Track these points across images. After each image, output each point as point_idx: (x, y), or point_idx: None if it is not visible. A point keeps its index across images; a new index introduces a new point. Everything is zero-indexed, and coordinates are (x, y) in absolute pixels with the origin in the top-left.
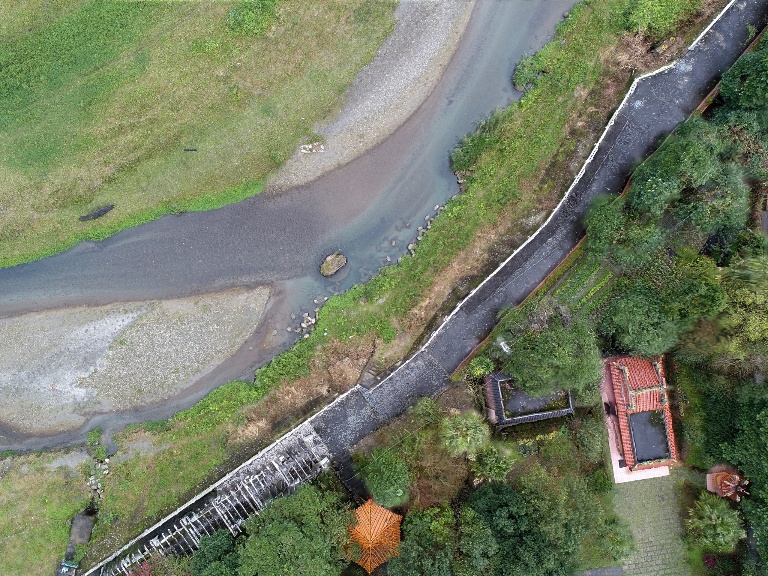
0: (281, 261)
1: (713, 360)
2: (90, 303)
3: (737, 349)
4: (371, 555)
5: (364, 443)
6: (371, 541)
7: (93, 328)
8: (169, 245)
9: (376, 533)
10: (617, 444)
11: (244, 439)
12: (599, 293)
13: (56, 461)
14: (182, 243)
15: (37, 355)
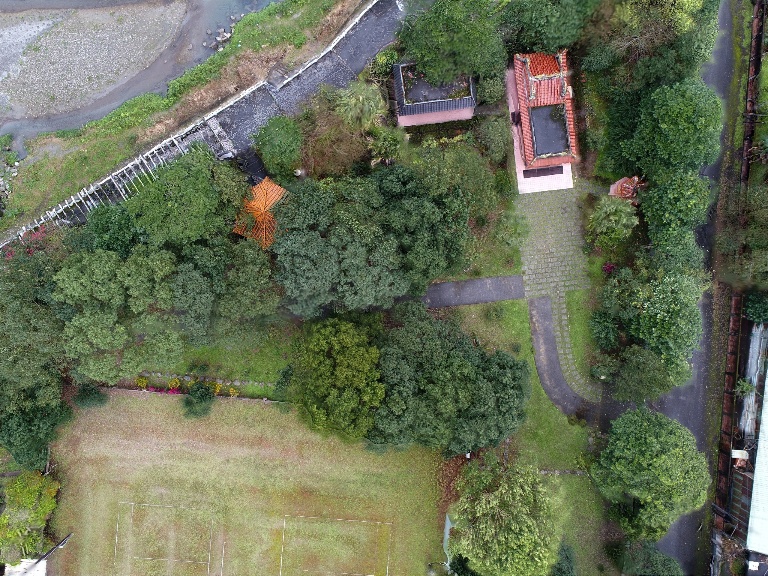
0: None
1: (612, 45)
2: (6, 9)
3: (633, 22)
4: (265, 230)
5: (269, 141)
6: (264, 210)
7: (8, 33)
8: None
9: (271, 206)
10: (520, 149)
11: (151, 137)
12: (511, 5)
13: None
14: None
15: None
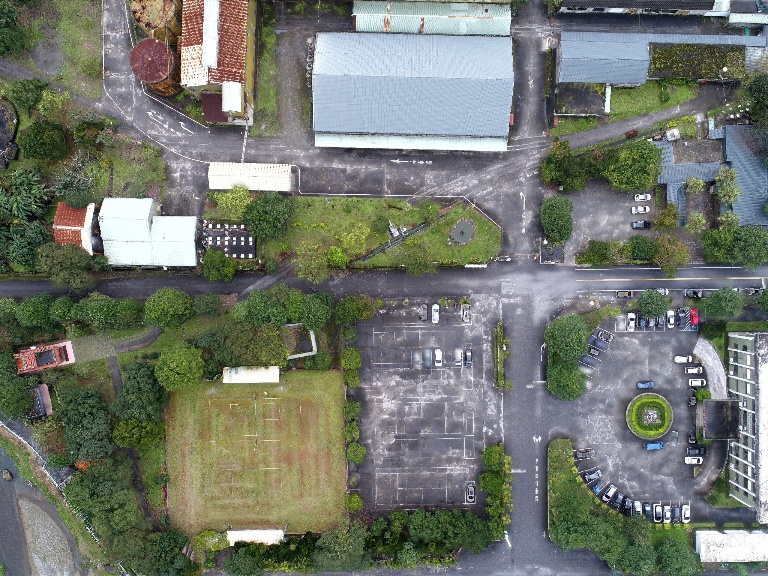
0: (8, 496)
1: (8, 341)
2: (30, 572)
3: None
4: None
5: None
6: None
7: (40, 570)
8: (5, 542)
9: None
10: None
11: None
12: (2, 373)
13: None
14: (4, 537)
15: None
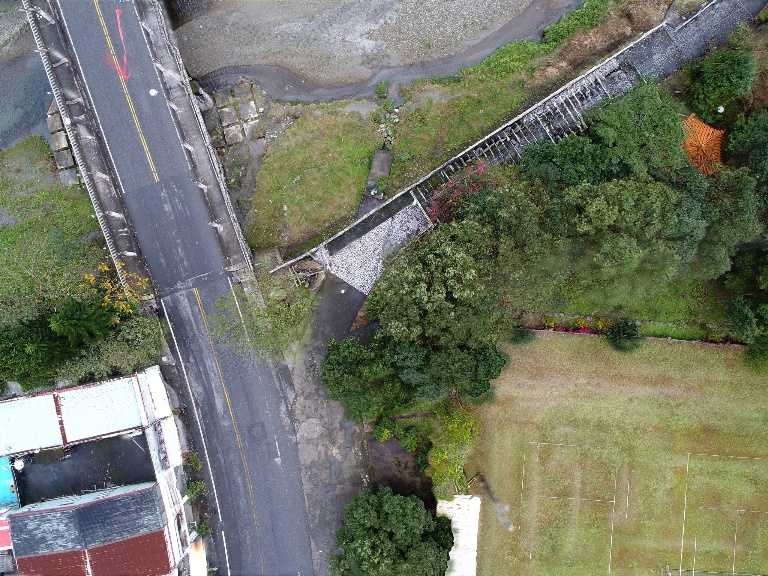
0: None
1: None
2: None
3: None
4: None
5: (668, 82)
6: None
7: None
8: None
9: (702, 142)
10: None
11: (544, 80)
12: None
13: (349, 106)
14: None
15: (328, 6)
